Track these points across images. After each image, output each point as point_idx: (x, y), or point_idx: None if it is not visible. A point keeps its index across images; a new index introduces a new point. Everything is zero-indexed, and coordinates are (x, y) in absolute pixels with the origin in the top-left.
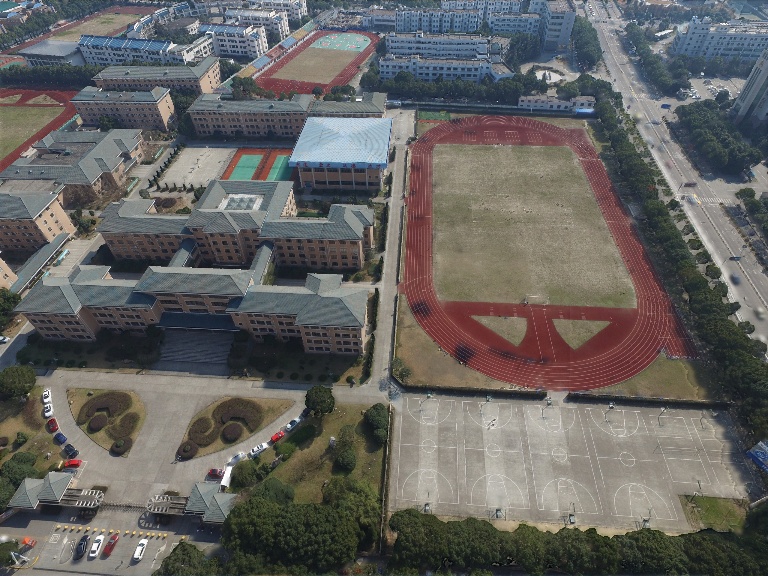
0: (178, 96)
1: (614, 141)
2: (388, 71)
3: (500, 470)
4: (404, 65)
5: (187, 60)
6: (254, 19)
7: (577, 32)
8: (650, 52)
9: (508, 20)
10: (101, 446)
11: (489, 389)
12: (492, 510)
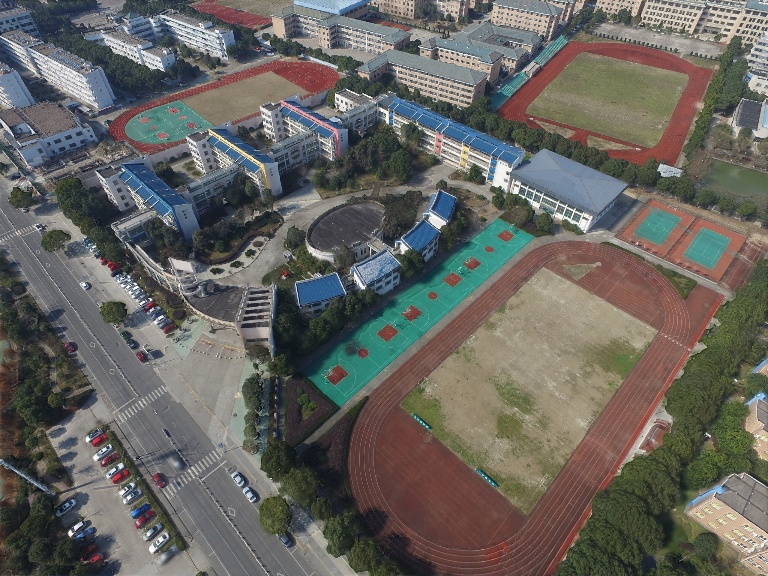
0: None
1: None
2: None
3: None
4: None
5: None
6: None
7: None
8: None
9: None
10: None
11: None
12: None
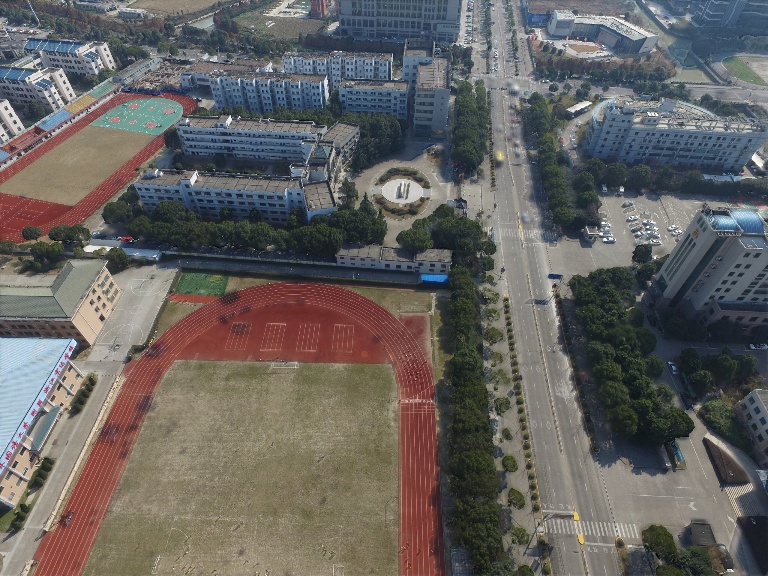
0: None
1: (455, 373)
2: (151, 195)
3: None
4: (171, 189)
5: None
6: (12, 82)
7: (457, 113)
8: (551, 153)
9: (364, 93)
10: None
11: None
12: None
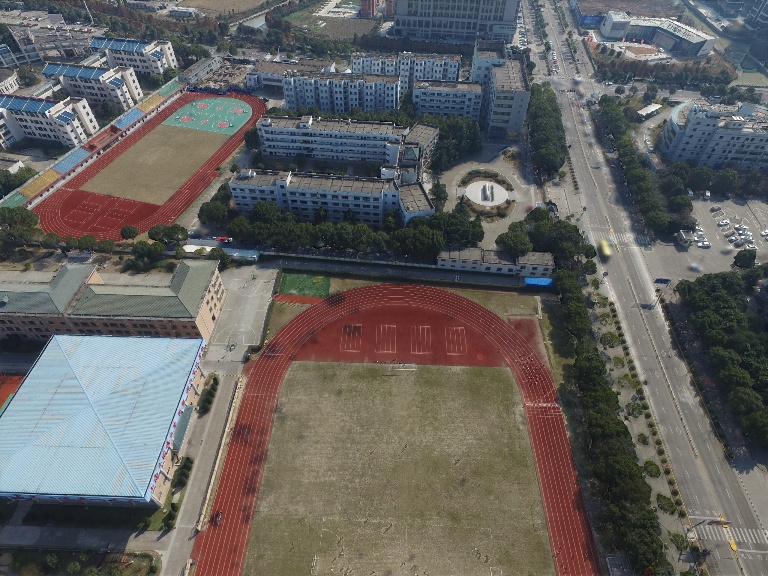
0: None
1: (582, 378)
2: (244, 195)
3: None
4: (267, 189)
5: None
6: (83, 81)
7: (533, 115)
8: (634, 157)
9: (438, 94)
10: None
11: None
12: None
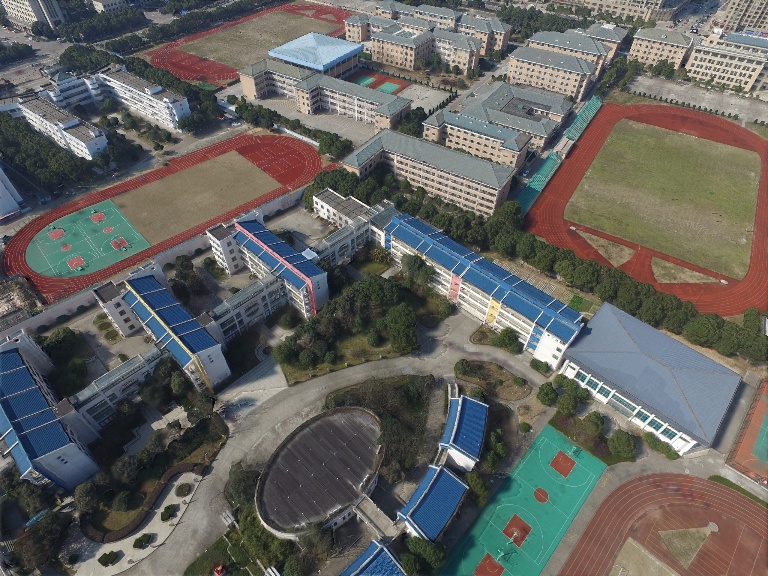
0: (415, 136)
1: (163, 30)
2: None
3: (368, 4)
4: None
5: None
6: None
7: None
8: None
9: None
10: None
11: (354, 9)
12: (377, 2)
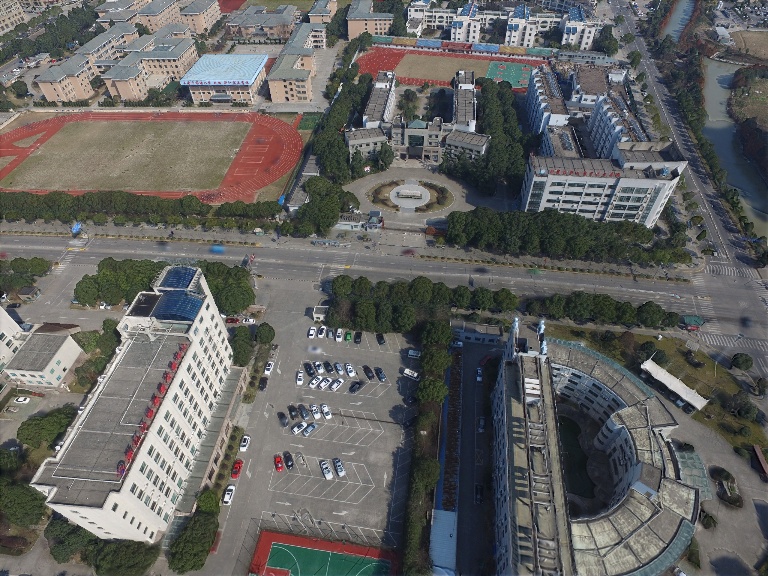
0: None
1: None
2: None
3: None
4: None
5: (412, 16)
6: None
7: None
8: (461, 288)
9: None
10: (57, 64)
11: None
12: None
